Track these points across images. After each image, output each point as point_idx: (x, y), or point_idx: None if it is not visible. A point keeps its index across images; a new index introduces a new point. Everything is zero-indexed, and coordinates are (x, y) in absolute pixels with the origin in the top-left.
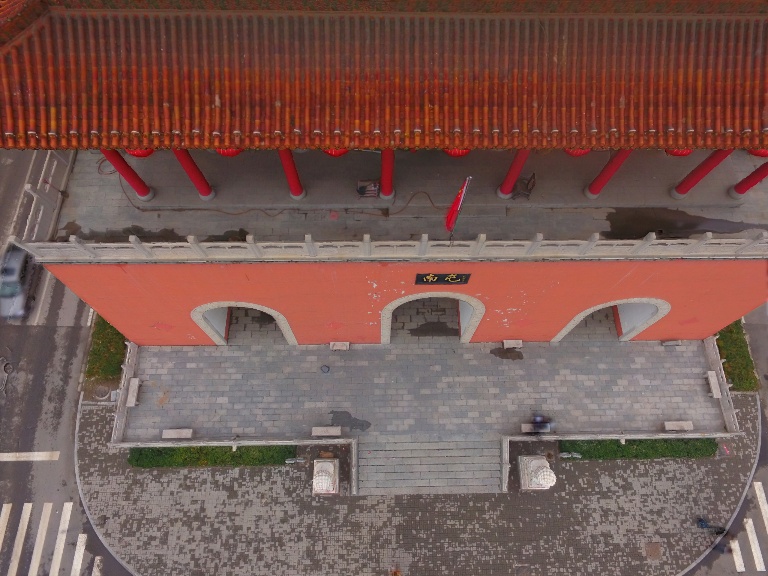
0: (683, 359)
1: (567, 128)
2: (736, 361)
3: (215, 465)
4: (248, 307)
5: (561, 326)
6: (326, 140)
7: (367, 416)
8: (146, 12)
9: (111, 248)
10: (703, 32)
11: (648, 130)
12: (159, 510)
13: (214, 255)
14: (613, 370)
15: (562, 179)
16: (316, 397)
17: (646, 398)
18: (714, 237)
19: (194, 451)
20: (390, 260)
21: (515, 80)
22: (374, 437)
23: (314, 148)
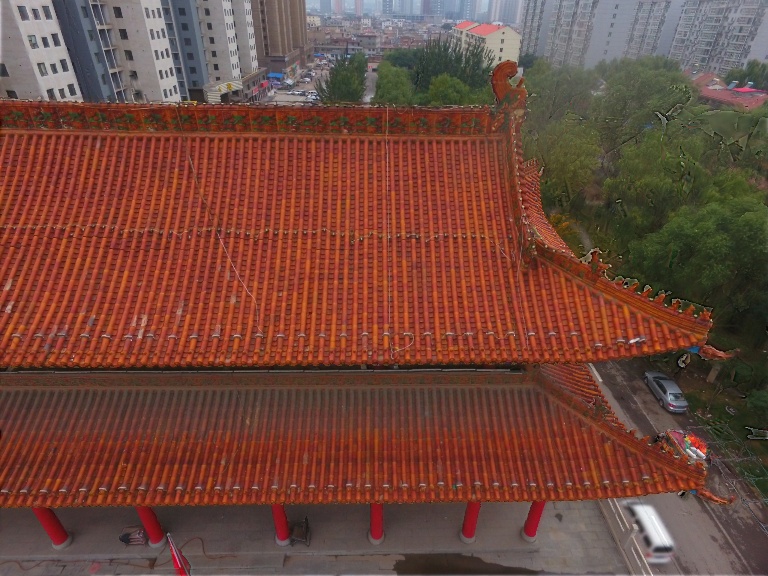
0: None
1: (250, 484)
2: None
3: None
4: None
5: None
6: (9, 499)
7: None
8: None
9: None
10: (377, 398)
11: (327, 485)
12: None
13: None
14: None
15: (349, 521)
16: None
17: None
18: None
19: None
20: None
21: (209, 440)
22: None
23: None
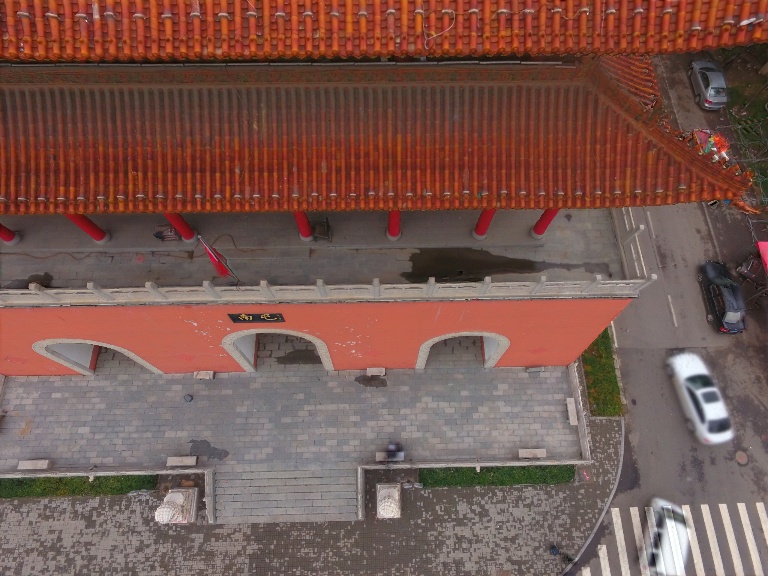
0: (546, 385)
1: (270, 192)
2: (602, 386)
3: (76, 494)
4: (85, 343)
5: (415, 355)
6: (31, 207)
7: (226, 445)
8: None
9: None
10: (399, 99)
11: (349, 194)
12: (16, 540)
13: (12, 300)
14: (475, 397)
15: (368, 220)
16: (177, 426)
17: (505, 425)
18: (514, 277)
19: (53, 481)
20: (188, 303)
21: (217, 146)
22: (231, 466)
23: None
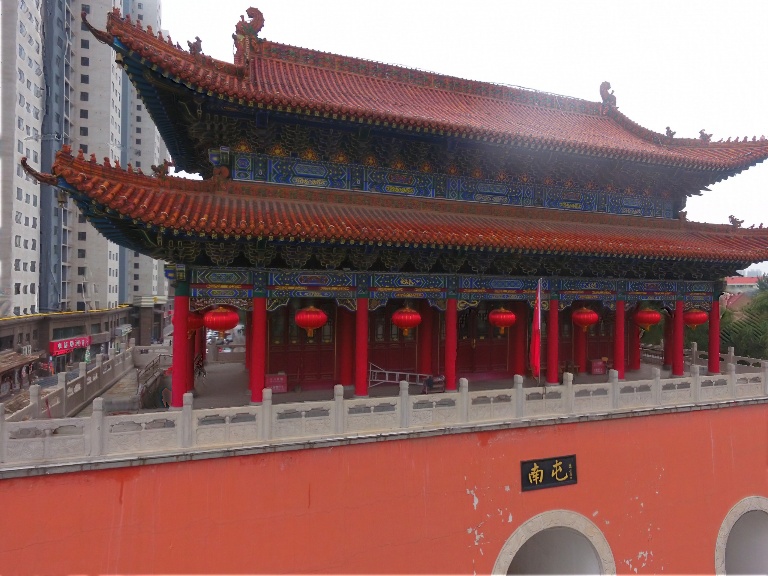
0: None
1: None
2: None
3: None
4: None
5: None
6: None
7: None
8: (286, 200)
9: (137, 430)
10: None
11: None
12: None
13: (280, 437)
14: None
15: None
16: None
17: None
18: None
19: None
20: (490, 426)
21: None
22: None
23: (426, 241)
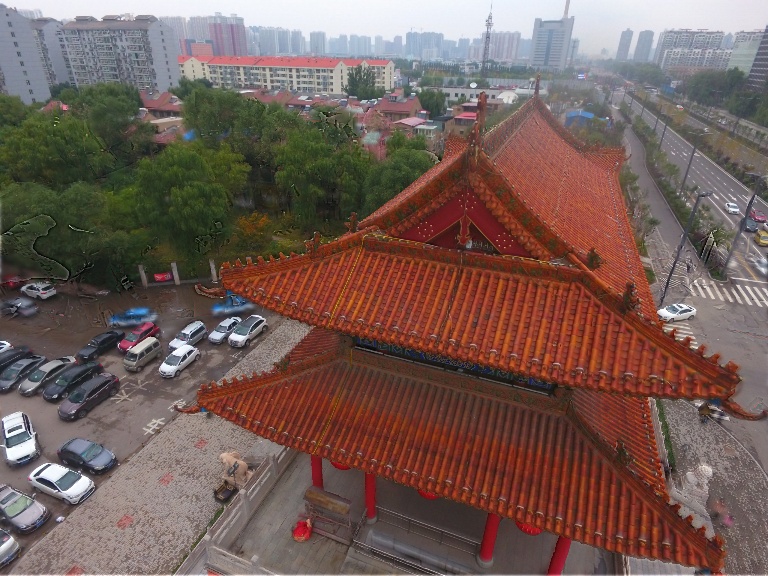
0: None
1: None
2: None
3: None
4: None
5: None
6: None
7: None
8: None
9: None
10: None
11: None
12: None
13: None
14: None
15: None
16: None
17: None
18: None
19: None
20: None
21: None
22: None
23: None
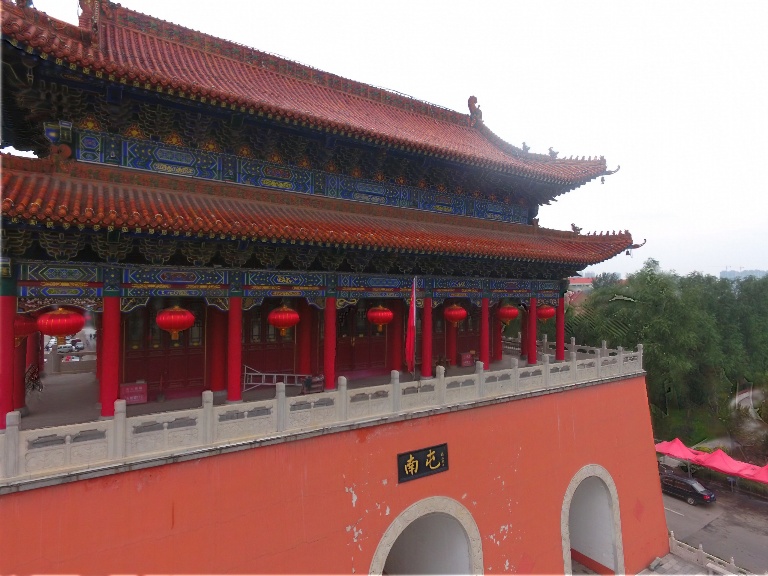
0: (680, 573)
1: None
2: None
3: None
4: None
5: (560, 563)
6: None
7: None
8: (145, 188)
9: None
10: None
11: None
12: None
13: (136, 454)
14: None
15: None
16: None
17: None
18: None
19: None
20: (368, 422)
21: None
22: None
23: (303, 238)
